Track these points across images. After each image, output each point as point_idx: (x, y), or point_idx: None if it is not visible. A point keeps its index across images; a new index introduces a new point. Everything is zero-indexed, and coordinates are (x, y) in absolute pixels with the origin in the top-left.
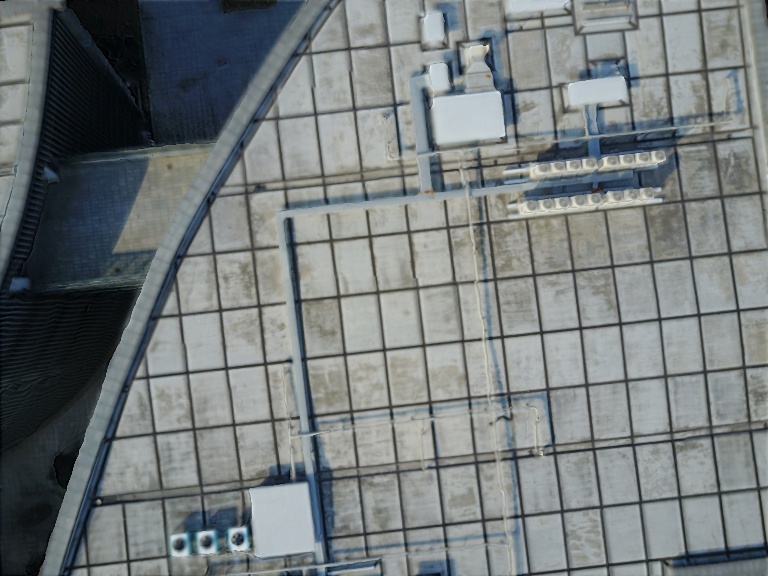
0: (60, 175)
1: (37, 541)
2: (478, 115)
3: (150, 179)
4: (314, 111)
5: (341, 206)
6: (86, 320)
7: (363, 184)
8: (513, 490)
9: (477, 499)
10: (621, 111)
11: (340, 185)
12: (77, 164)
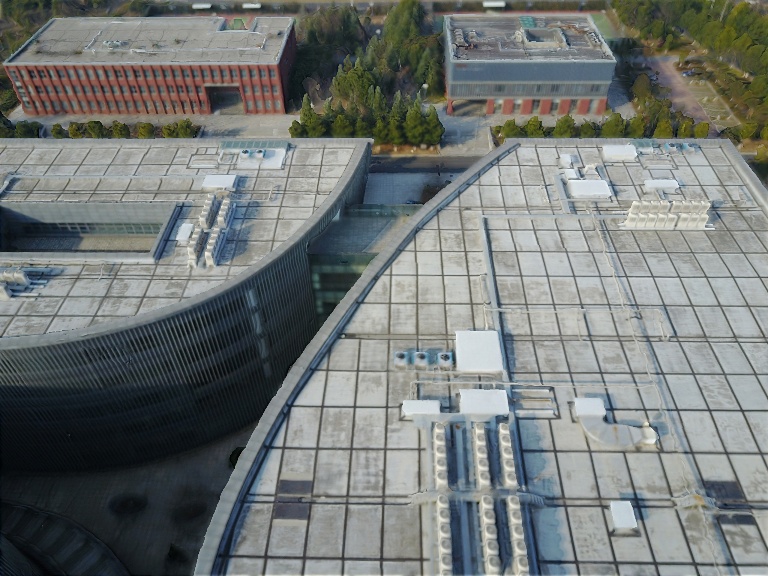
0: (340, 217)
1: (183, 534)
2: (594, 186)
3: (392, 224)
4: (500, 184)
5: (517, 215)
6: (305, 333)
7: (529, 211)
8: (652, 358)
9: (625, 361)
10: (678, 196)
11: (515, 211)
12: (352, 212)
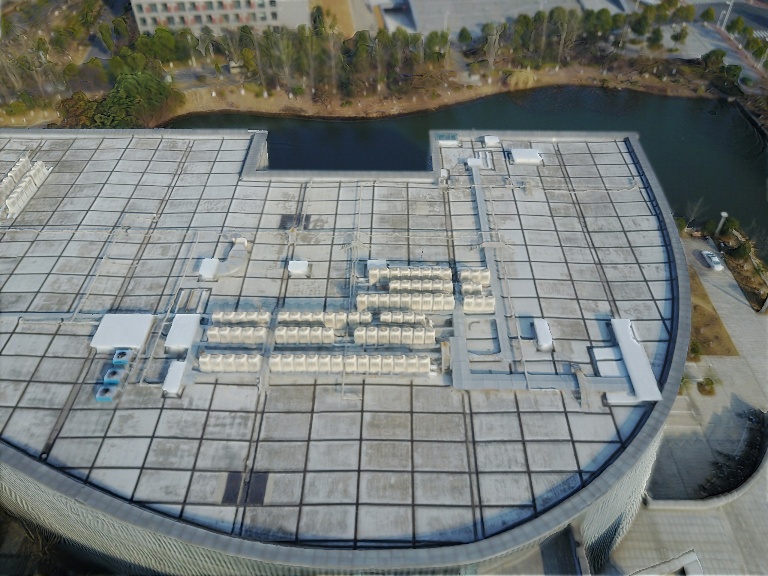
0: None
1: None
2: None
3: None
4: None
5: None
6: None
7: None
8: None
9: None
10: None
11: None
12: None
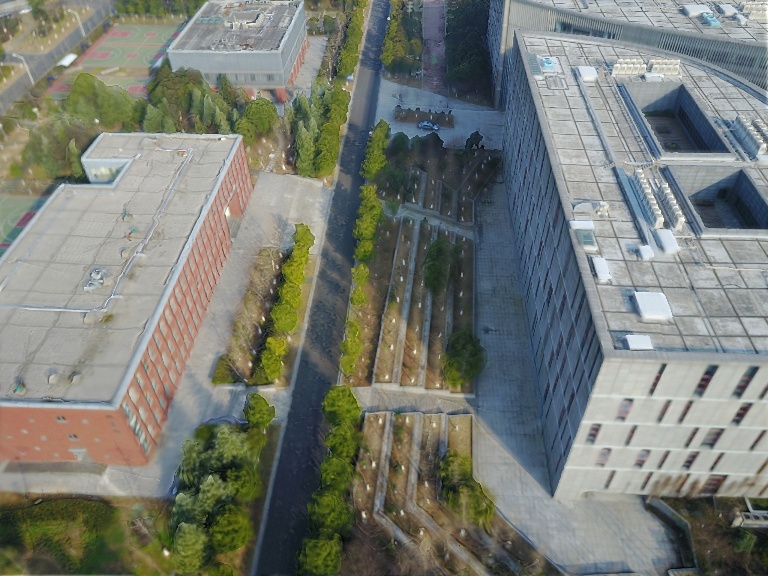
0: None
1: None
2: None
3: None
4: None
5: None
6: None
7: None
8: None
9: None
10: None
11: (577, 2)
12: None
